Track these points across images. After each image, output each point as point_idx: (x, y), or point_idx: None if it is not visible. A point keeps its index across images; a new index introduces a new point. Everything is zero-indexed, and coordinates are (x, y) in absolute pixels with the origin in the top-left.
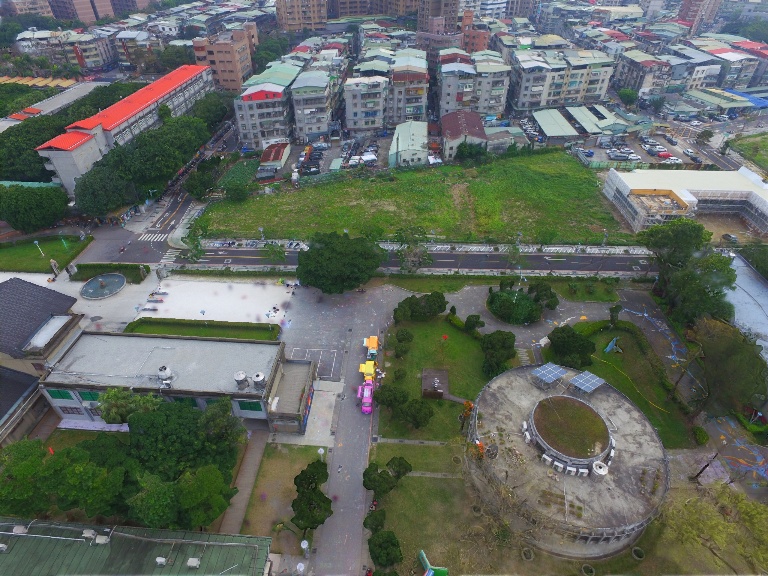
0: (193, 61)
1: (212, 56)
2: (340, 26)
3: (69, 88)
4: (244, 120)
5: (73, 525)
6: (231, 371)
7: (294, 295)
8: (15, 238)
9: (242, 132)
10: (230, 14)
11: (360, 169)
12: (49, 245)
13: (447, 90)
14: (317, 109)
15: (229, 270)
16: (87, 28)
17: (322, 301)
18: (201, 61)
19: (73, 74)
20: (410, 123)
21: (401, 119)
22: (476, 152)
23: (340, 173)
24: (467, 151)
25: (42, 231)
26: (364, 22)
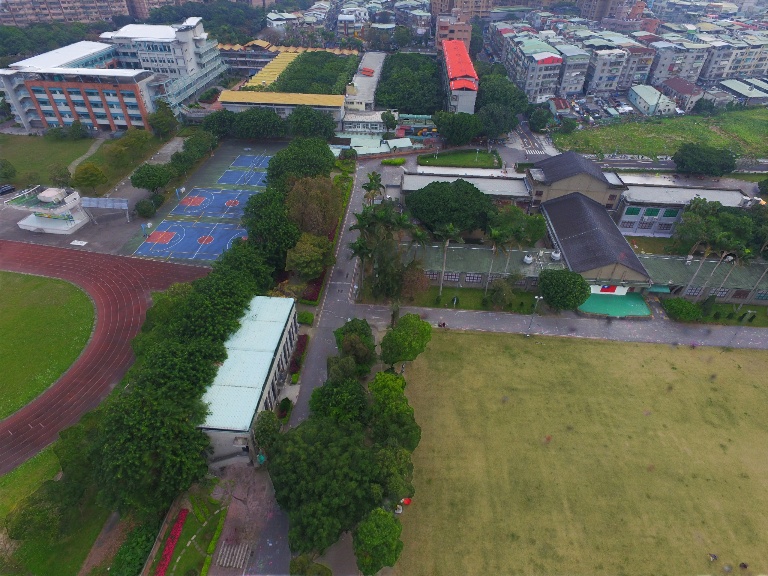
0: (409, 40)
1: (452, 34)
2: (500, 14)
3: (362, 56)
4: (532, 79)
5: (711, 258)
6: (727, 200)
7: (675, 182)
8: (440, 151)
9: (527, 89)
10: (388, 3)
11: (632, 115)
12: (471, 155)
13: (663, 62)
14: (580, 73)
15: (618, 168)
16: (298, 12)
17: (697, 185)
18: (442, 38)
19: (356, 46)
20: (643, 86)
21: (628, 84)
22: (708, 106)
23: (621, 117)
24: (704, 104)
25: (454, 147)
26: (531, 11)
